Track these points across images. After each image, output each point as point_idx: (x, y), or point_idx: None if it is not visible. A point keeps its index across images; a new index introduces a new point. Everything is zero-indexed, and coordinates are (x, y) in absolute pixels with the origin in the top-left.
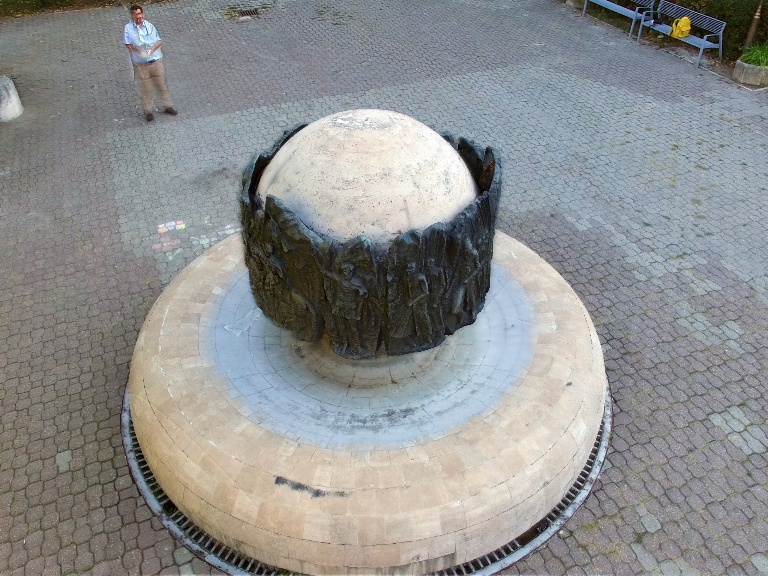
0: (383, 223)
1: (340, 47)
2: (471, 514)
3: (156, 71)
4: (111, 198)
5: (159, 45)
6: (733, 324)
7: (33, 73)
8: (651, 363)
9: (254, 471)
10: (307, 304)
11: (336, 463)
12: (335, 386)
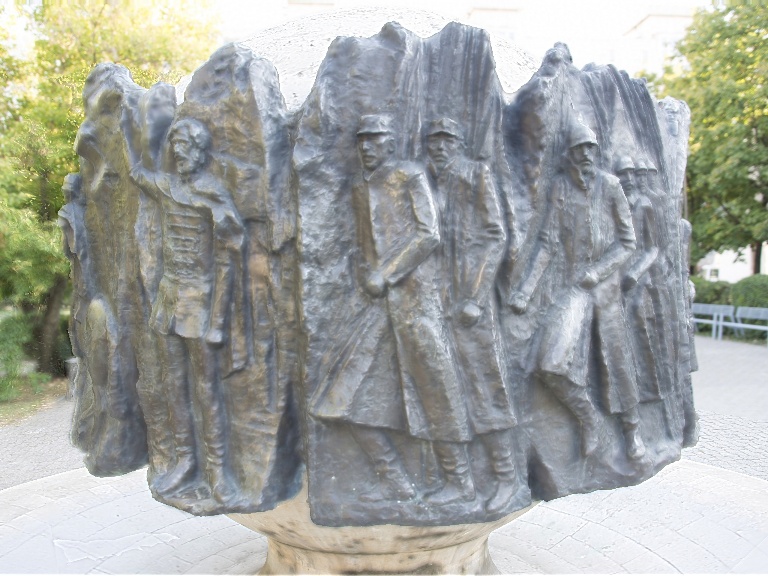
0: None
1: None
2: None
3: None
4: None
5: None
6: None
7: None
8: None
9: None
10: (106, 318)
11: None
12: None
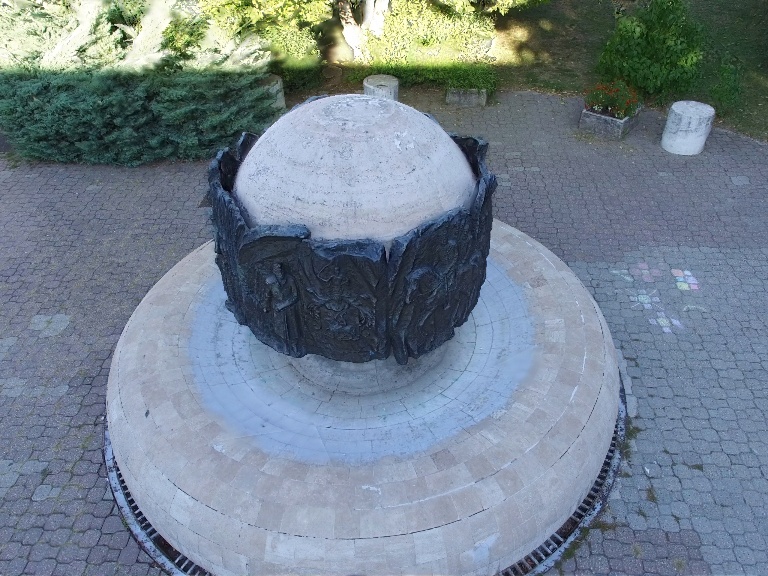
0: None
1: None
2: None
3: None
4: (763, 246)
5: None
6: None
7: None
8: None
9: None
10: None
11: None
12: None
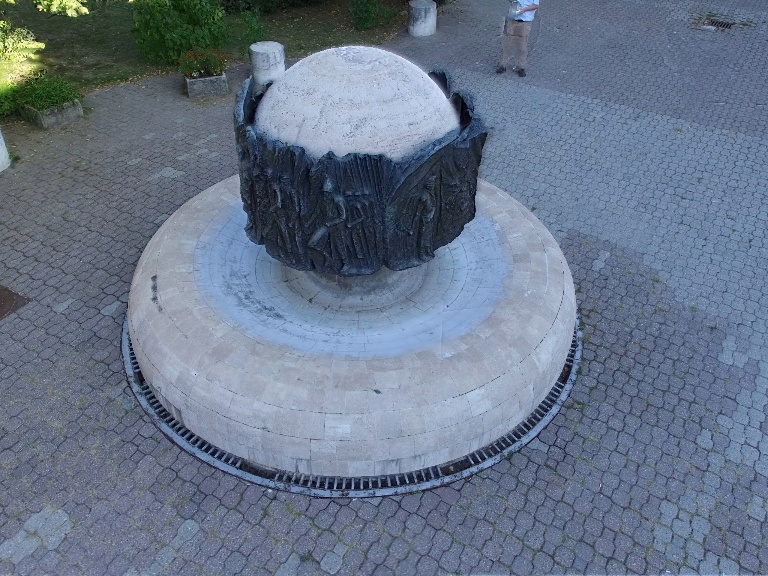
0: (281, 130)
1: (761, 82)
2: (197, 390)
3: (520, 31)
4: None
5: (533, 8)
6: (732, 567)
7: (476, 12)
8: (559, 495)
9: (155, 264)
10: None
11: (184, 294)
12: (280, 274)
